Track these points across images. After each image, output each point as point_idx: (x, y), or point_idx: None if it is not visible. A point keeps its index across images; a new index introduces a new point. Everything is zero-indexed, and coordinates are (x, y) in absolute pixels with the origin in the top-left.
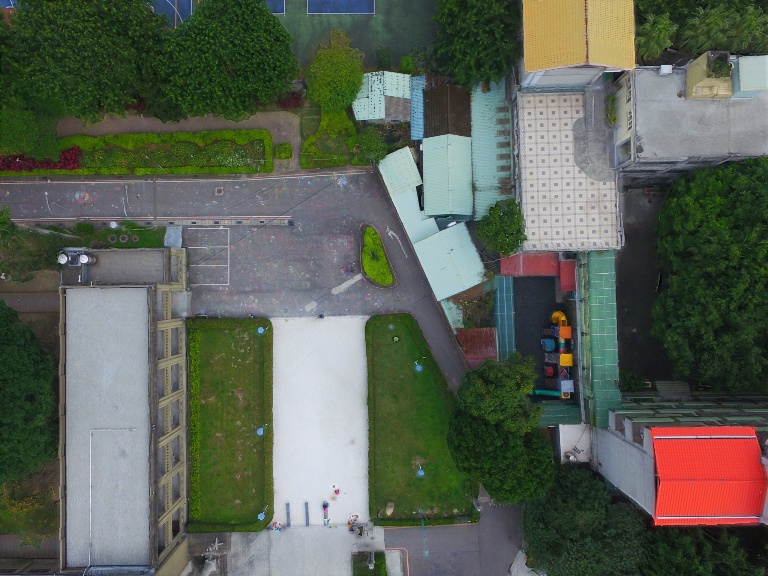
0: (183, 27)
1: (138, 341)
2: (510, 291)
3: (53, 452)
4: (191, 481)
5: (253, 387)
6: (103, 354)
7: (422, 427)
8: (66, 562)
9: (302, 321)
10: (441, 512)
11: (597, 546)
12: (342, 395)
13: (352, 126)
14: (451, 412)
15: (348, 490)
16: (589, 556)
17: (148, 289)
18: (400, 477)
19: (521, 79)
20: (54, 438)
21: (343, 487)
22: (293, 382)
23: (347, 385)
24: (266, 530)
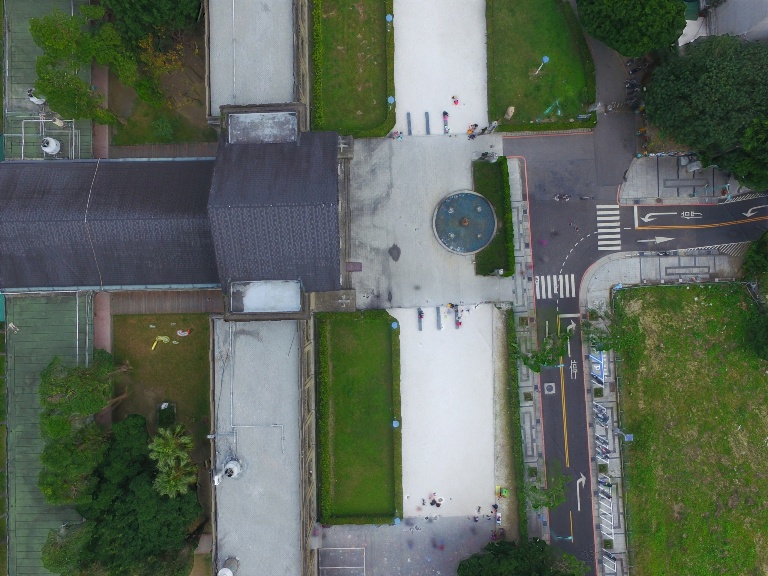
0: None
1: None
2: None
3: (195, 9)
4: (314, 91)
5: (373, 1)
6: None
7: (538, 39)
8: (210, 113)
9: None
10: (558, 121)
11: (738, 57)
12: (460, 10)
13: None
14: (567, 25)
15: (467, 101)
16: (731, 65)
17: None
18: (517, 88)
19: None
20: None
21: (462, 98)
22: None
23: (465, 0)
24: (387, 139)
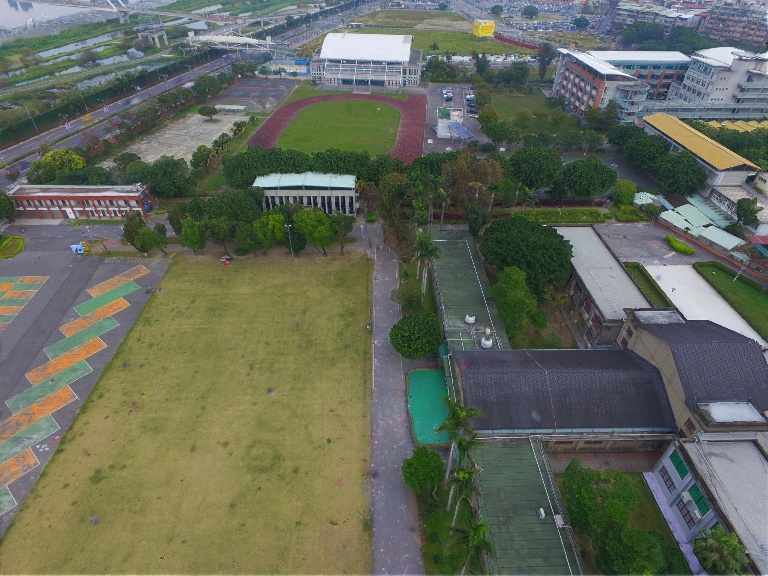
0: (576, 162)
1: (595, 241)
2: (763, 247)
3: None
4: None
5: None
6: (579, 245)
7: None
8: None
9: (655, 267)
10: None
11: None
12: None
13: (636, 209)
14: None
15: None
16: None
17: (592, 224)
18: None
19: (712, 183)
20: (570, 270)
21: None
22: (668, 288)
23: (701, 290)
24: None
